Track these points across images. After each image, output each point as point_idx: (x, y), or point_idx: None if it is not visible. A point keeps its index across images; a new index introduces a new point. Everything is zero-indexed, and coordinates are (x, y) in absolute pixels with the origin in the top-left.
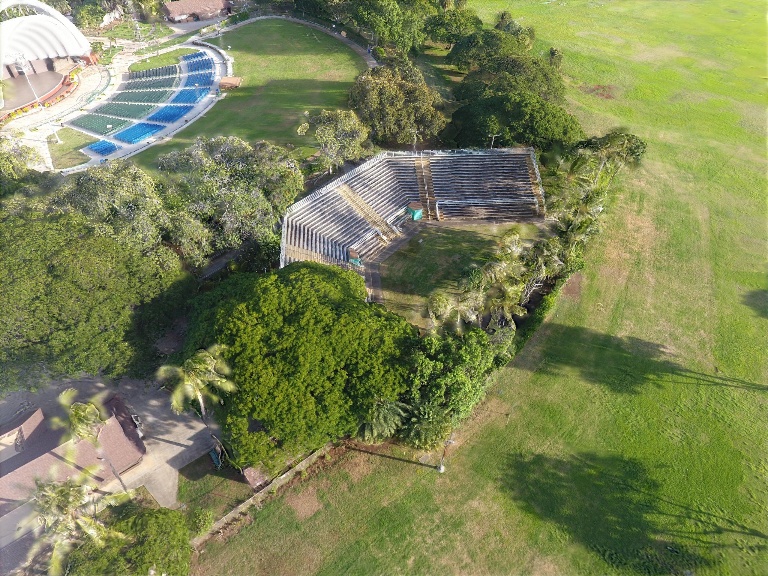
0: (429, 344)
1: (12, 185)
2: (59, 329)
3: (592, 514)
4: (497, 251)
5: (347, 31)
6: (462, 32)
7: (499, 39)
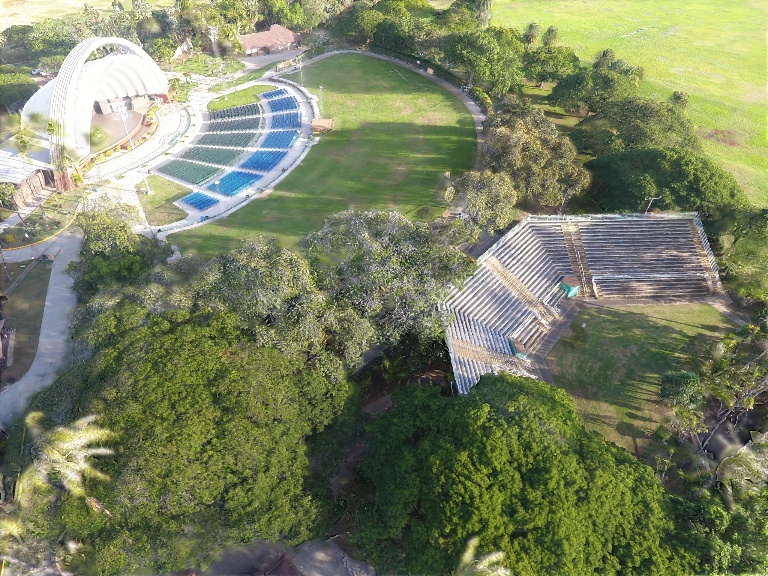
0: (717, 518)
1: (127, 259)
2: (234, 483)
3: None
4: (765, 378)
5: (435, 68)
6: (559, 70)
7: (612, 80)
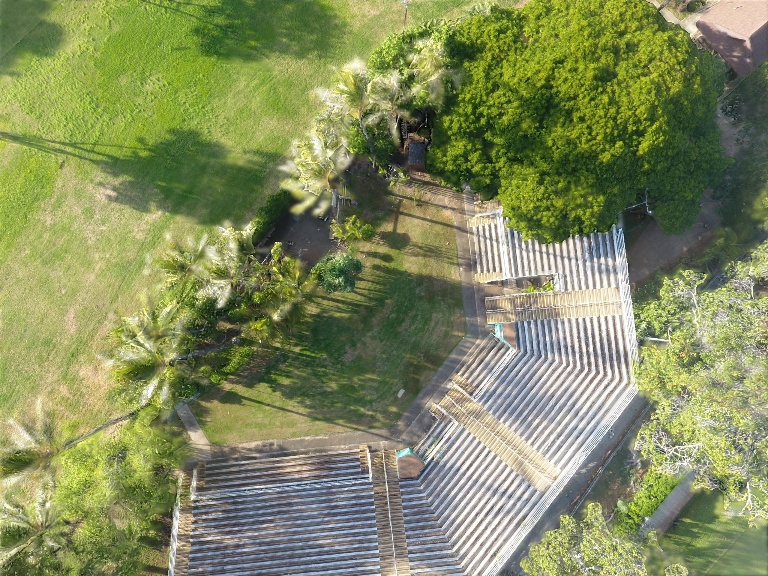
0: None
1: None
2: None
3: (268, 5)
4: None
5: None
6: None
7: None
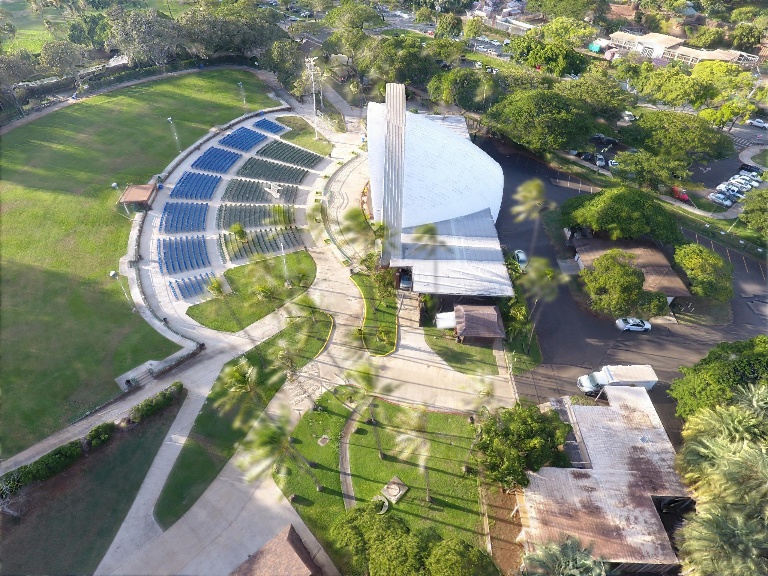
0: None
1: None
2: None
3: None
4: None
5: None
6: None
7: None
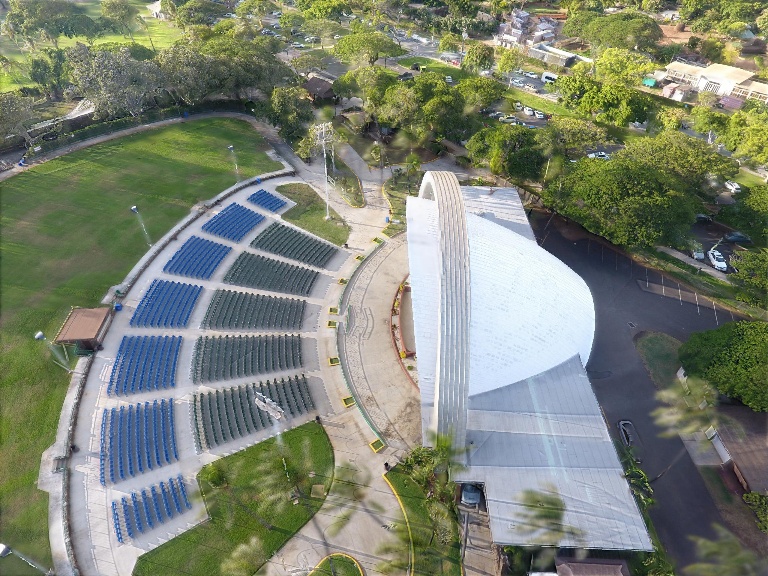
0: None
1: None
2: None
3: None
4: None
5: None
6: None
7: None
